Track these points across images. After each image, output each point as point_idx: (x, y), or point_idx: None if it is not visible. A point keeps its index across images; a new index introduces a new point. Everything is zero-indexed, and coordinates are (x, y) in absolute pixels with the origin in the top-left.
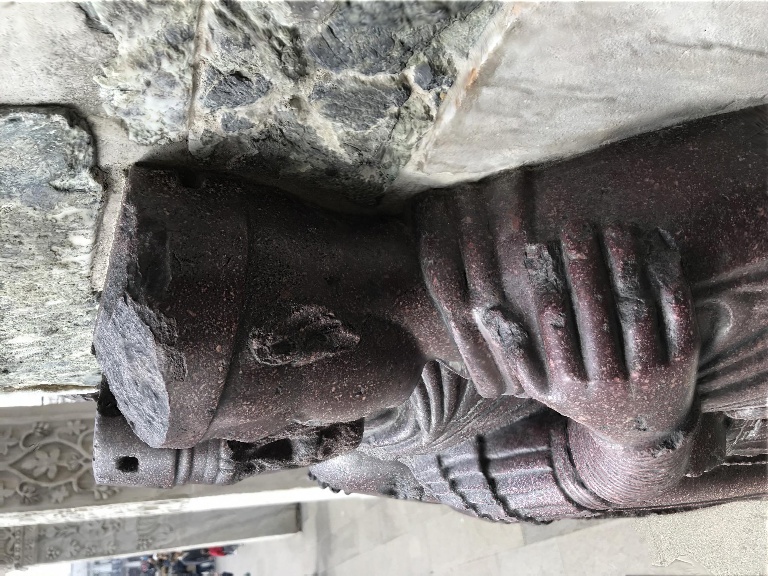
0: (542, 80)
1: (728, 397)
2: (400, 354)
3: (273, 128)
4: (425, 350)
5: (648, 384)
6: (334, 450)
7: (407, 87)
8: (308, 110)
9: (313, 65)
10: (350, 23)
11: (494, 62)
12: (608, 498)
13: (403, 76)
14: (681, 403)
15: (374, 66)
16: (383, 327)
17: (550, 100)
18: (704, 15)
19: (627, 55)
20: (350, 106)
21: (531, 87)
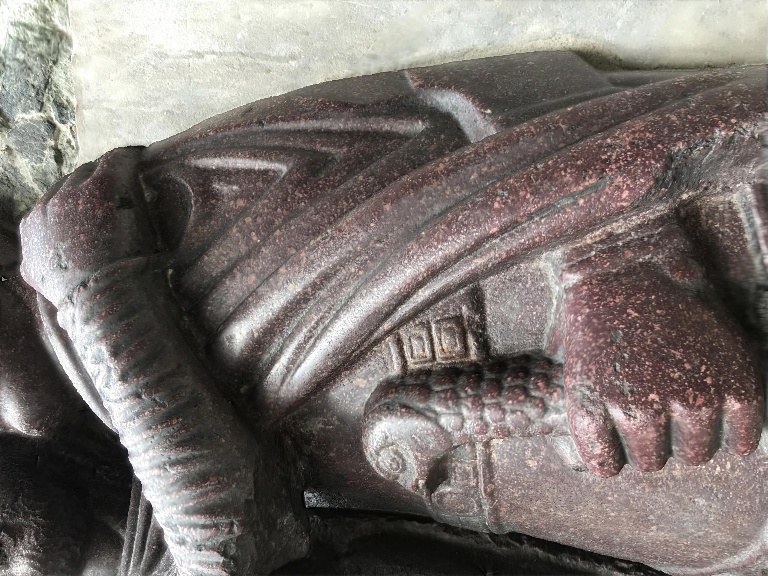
0: (114, 100)
1: (236, 315)
2: (7, 315)
3: (4, 176)
4: (42, 333)
5: (58, 204)
6: (10, 561)
7: (52, 124)
8: (16, 156)
9: (13, 123)
10: (8, 79)
11: (79, 89)
12: (177, 565)
13: (50, 118)
14: (97, 235)
15: (27, 106)
16: (5, 292)
17: (129, 118)
18: (178, 34)
19: (154, 73)
20: (26, 141)
21: (111, 107)
